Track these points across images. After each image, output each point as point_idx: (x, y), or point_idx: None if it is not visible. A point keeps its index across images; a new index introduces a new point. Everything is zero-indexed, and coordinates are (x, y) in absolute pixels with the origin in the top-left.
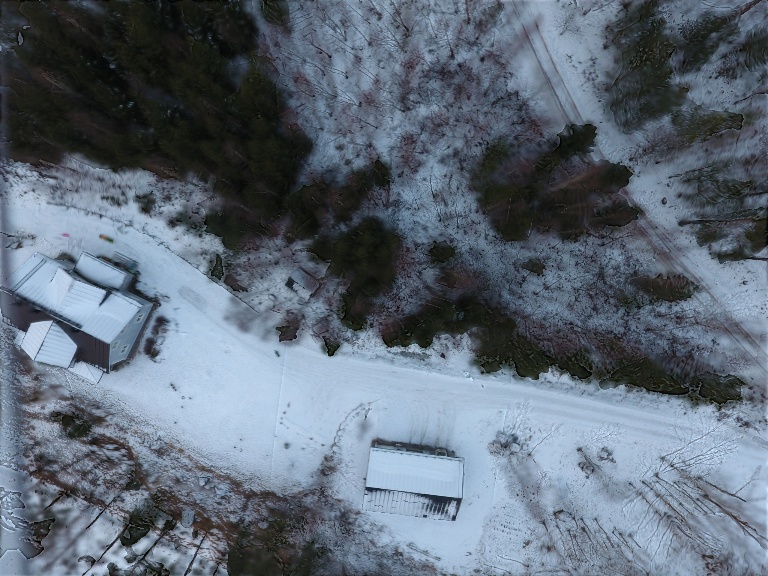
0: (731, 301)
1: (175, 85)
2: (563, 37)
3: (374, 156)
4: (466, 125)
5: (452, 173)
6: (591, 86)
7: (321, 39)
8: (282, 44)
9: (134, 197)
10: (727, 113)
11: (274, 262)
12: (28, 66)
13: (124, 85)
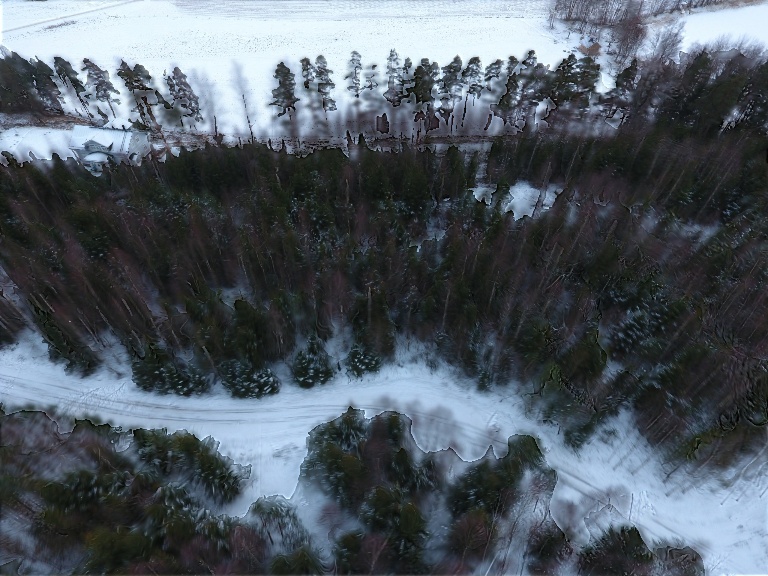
0: None
1: None
2: None
3: None
4: None
5: None
6: None
7: None
8: None
9: None
10: None
11: None
12: None
13: None
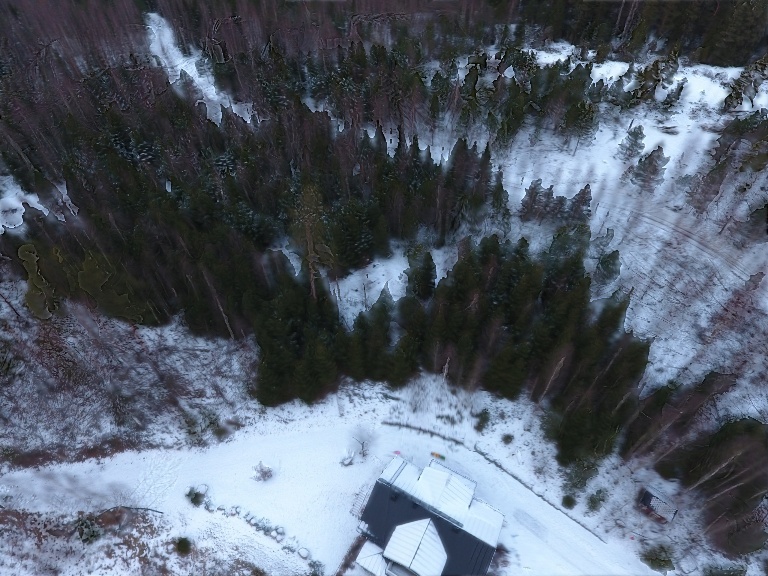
0: None
1: (561, 306)
2: None
3: (692, 377)
4: (760, 355)
5: (766, 393)
6: None
7: None
8: None
9: (468, 416)
10: None
11: (613, 482)
12: (441, 299)
13: None
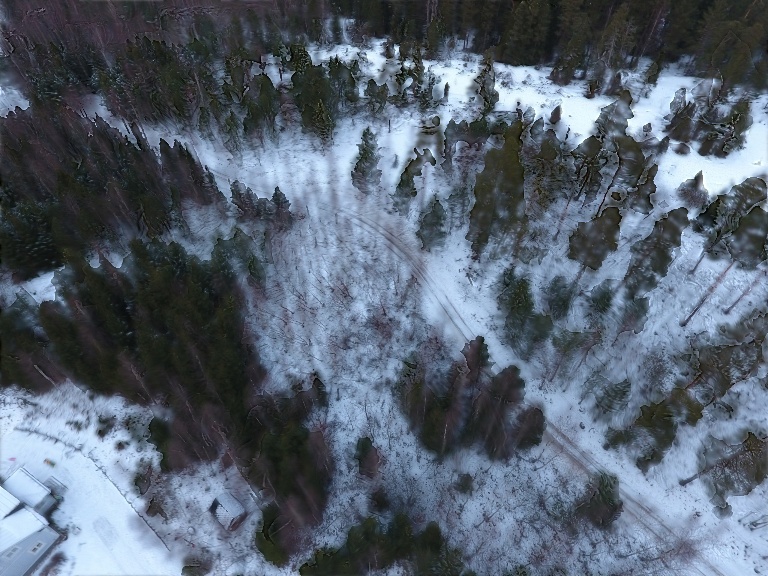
0: (693, 537)
1: (168, 313)
2: (466, 303)
3: None
4: (396, 360)
5: (384, 398)
6: (494, 334)
7: (288, 303)
8: (259, 306)
9: (96, 422)
10: (588, 333)
11: (205, 488)
12: (67, 304)
13: (131, 322)
